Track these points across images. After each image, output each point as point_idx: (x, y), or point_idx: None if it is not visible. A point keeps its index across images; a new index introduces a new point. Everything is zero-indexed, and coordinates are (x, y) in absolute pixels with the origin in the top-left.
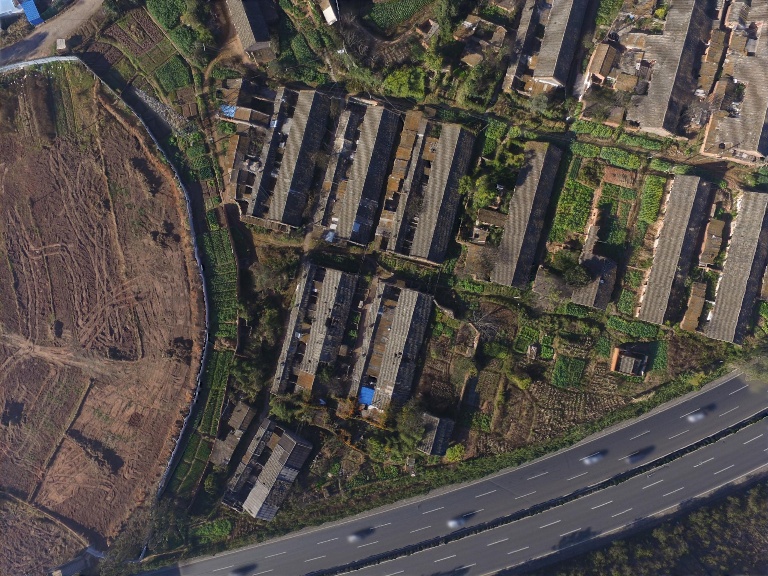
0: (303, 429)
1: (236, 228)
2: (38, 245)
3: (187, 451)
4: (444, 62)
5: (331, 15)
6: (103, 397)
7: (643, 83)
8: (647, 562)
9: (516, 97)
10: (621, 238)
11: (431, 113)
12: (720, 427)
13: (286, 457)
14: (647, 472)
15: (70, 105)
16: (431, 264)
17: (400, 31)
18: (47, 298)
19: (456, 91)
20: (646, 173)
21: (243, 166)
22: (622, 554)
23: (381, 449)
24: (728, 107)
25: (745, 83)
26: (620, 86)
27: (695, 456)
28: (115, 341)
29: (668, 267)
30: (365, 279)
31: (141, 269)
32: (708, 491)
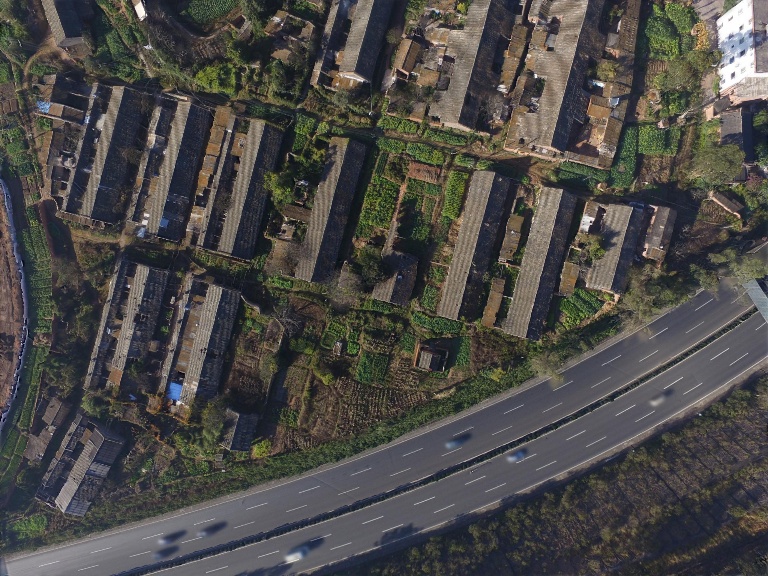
0: (115, 425)
1: (54, 224)
2: None
3: (6, 447)
4: (253, 58)
5: (142, 11)
6: None
7: (446, 78)
8: (458, 558)
9: (324, 93)
10: (424, 234)
11: (240, 109)
12: (543, 423)
13: (95, 452)
14: (470, 468)
15: None
16: (243, 260)
17: (217, 27)
18: None
19: (268, 87)
20: (451, 169)
21: (57, 162)
22: (436, 550)
23: (187, 445)
24: (528, 102)
25: (545, 78)
26: (422, 81)
27: (518, 452)
28: None
29: (464, 263)
30: (176, 275)
31: None
32: (530, 487)
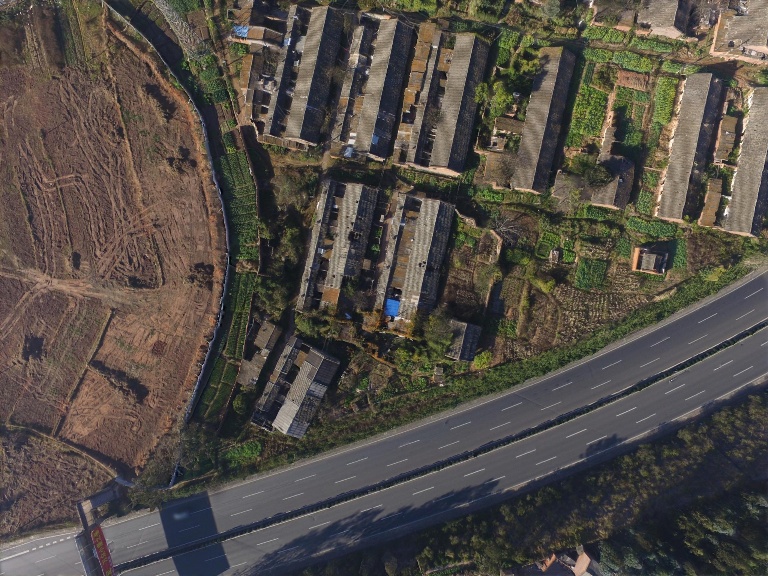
0: (330, 345)
1: (253, 149)
2: (51, 177)
3: (213, 375)
4: None
5: None
6: (125, 326)
7: None
8: (674, 461)
9: (528, 6)
10: (637, 140)
11: (444, 25)
12: (737, 330)
13: (314, 372)
14: (669, 377)
15: (78, 34)
16: (450, 176)
17: None
18: (63, 230)
19: (468, 3)
20: (658, 75)
21: (258, 85)
22: (649, 455)
23: (409, 359)
24: (736, 6)
25: None
26: None
27: (714, 360)
28: (135, 270)
29: (685, 163)
30: (385, 193)
31: (158, 196)
32: (729, 393)
